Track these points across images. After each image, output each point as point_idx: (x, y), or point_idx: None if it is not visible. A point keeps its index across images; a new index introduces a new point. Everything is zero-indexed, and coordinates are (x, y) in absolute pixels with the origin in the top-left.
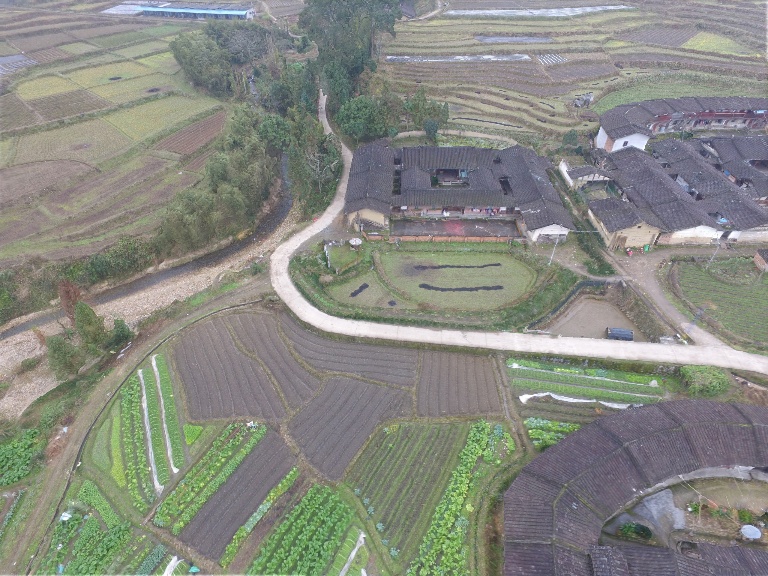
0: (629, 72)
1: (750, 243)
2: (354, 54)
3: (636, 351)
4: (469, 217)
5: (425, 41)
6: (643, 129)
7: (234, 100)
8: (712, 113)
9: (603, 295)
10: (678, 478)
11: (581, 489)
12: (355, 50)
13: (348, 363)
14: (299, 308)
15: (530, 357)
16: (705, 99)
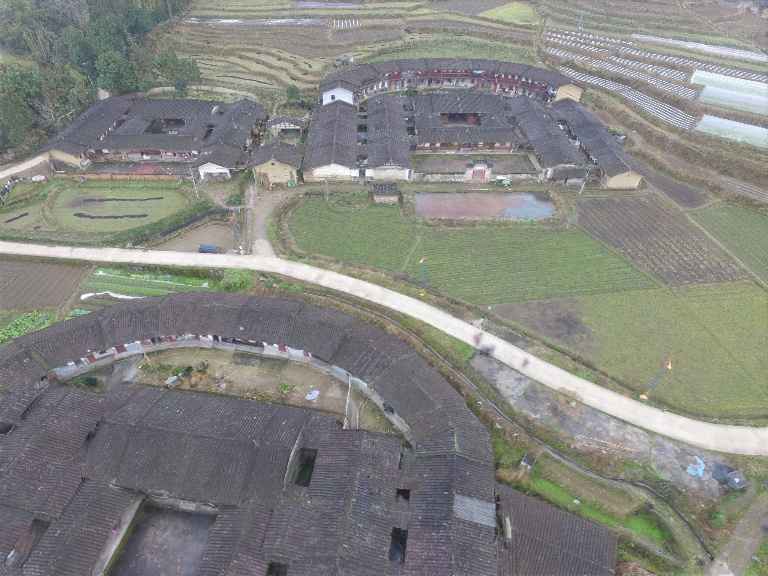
0: (413, 37)
1: (386, 181)
2: (126, 13)
3: (199, 260)
4: (166, 160)
5: (238, 5)
6: (352, 84)
7: (31, 58)
8: (439, 73)
9: (228, 221)
10: (156, 348)
11: (37, 349)
12: (127, 9)
13: None
14: None
15: (117, 266)
16: (433, 60)
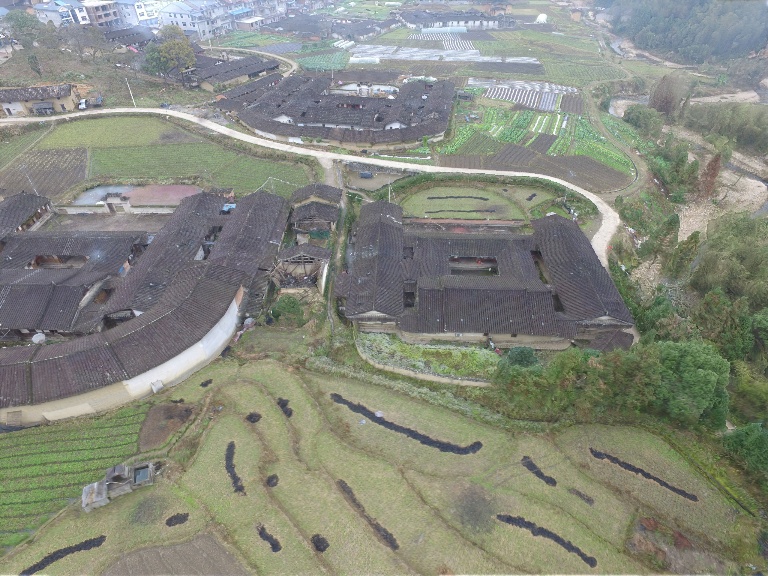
0: None
1: None
2: None
3: (366, 160)
4: None
5: None
6: None
7: None
8: None
9: None
10: None
11: None
12: None
13: (520, 169)
14: (566, 183)
15: None
16: None
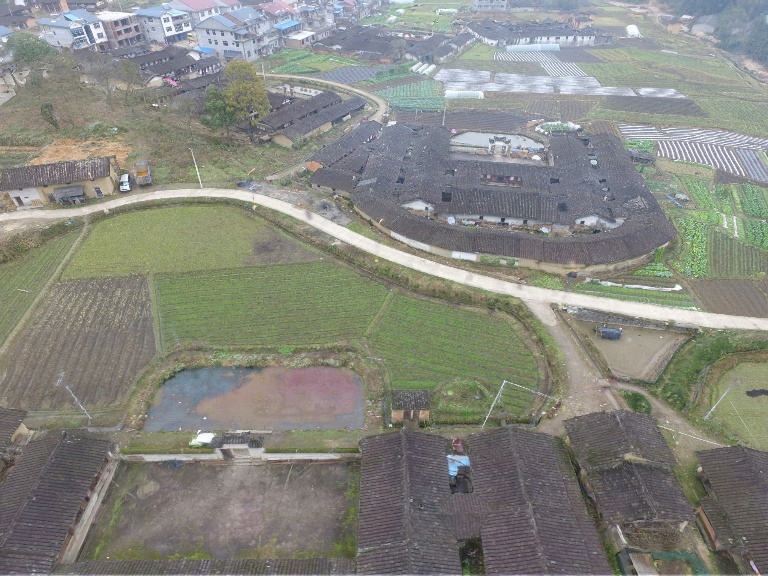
0: None
1: None
2: None
3: (600, 303)
4: None
5: None
6: None
7: None
8: None
9: None
10: None
11: None
12: None
13: None
14: None
15: None
16: None
